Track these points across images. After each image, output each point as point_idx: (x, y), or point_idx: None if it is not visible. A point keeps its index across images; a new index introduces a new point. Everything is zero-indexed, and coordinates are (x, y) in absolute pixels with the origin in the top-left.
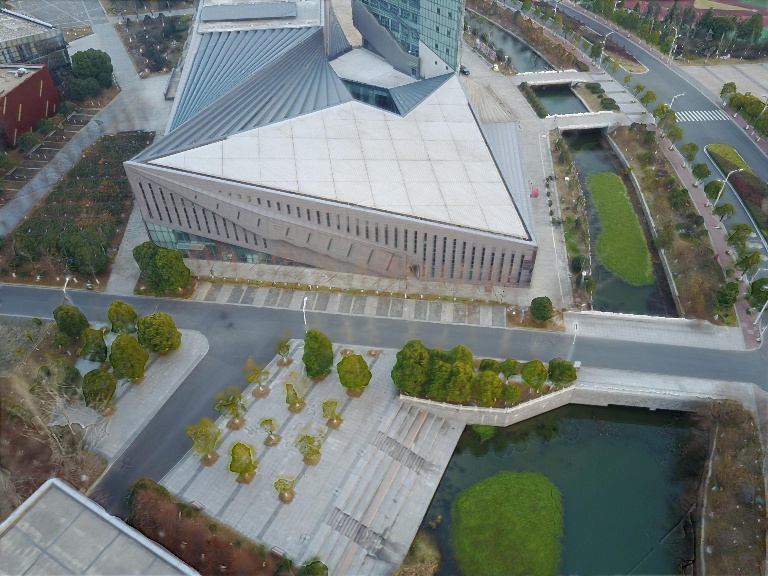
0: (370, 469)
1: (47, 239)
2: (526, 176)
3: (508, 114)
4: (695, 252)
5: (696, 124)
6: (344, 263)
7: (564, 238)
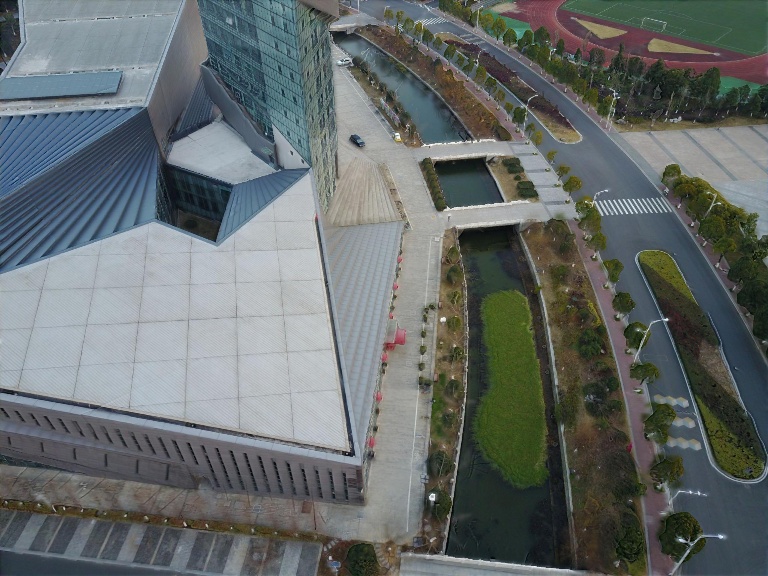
0: None
1: None
2: (385, 321)
3: (394, 209)
4: (602, 437)
5: (630, 219)
6: (106, 471)
7: (431, 410)
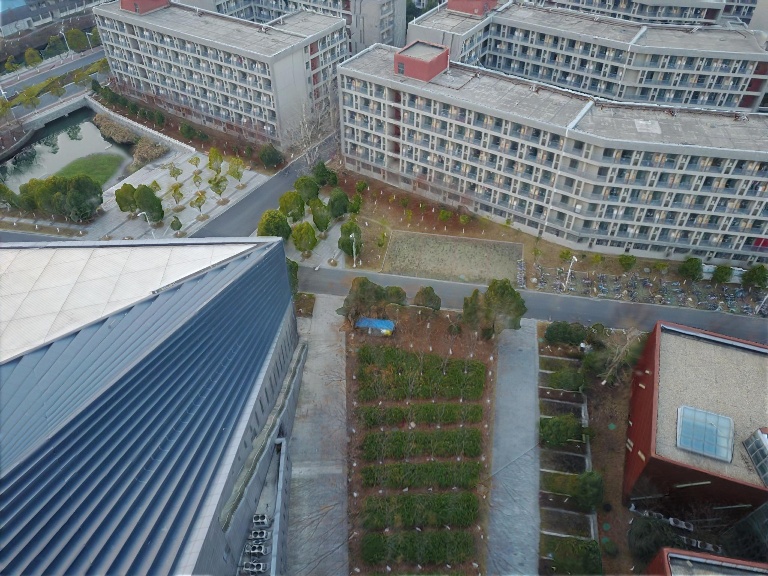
0: (145, 182)
1: (398, 289)
2: None
3: None
4: None
5: None
6: None
7: None
